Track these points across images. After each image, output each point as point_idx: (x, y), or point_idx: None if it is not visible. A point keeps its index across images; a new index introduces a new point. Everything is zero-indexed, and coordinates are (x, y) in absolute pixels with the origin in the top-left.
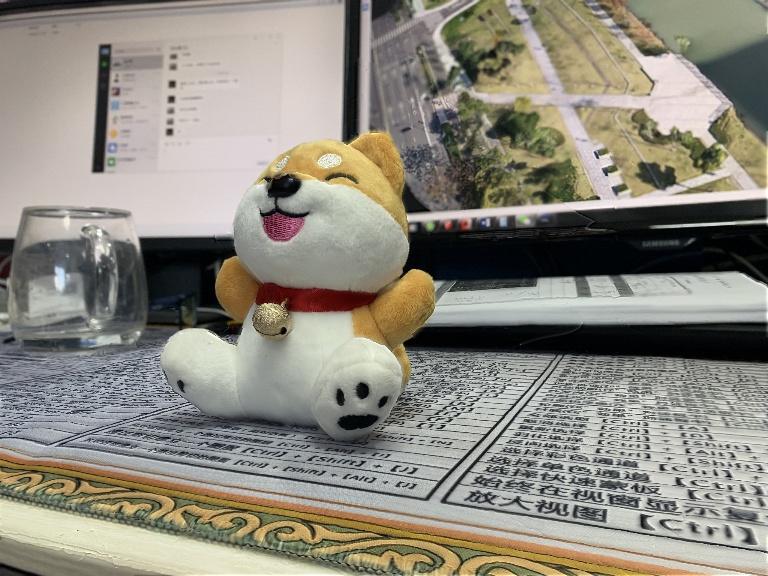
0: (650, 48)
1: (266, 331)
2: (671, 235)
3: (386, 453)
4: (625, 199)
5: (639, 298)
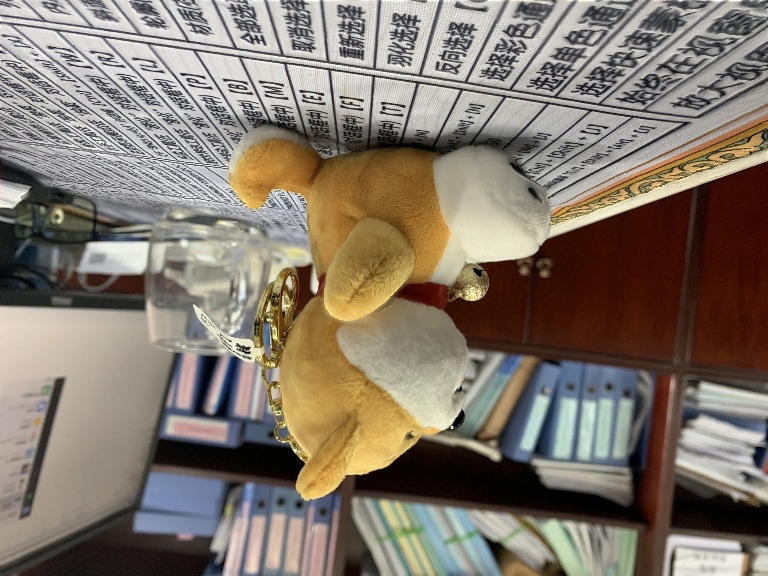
0: None
1: None
2: None
3: None
4: None
5: None
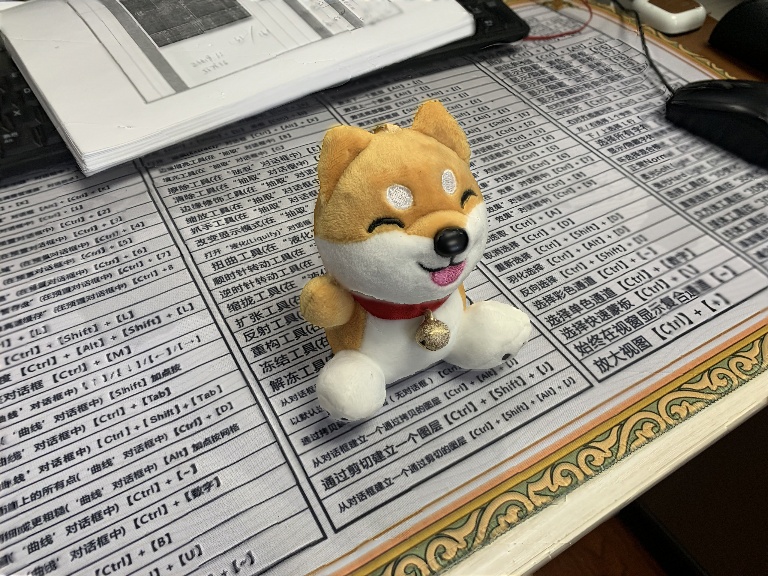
0: None
1: None
2: None
3: None
4: None
5: (371, 29)
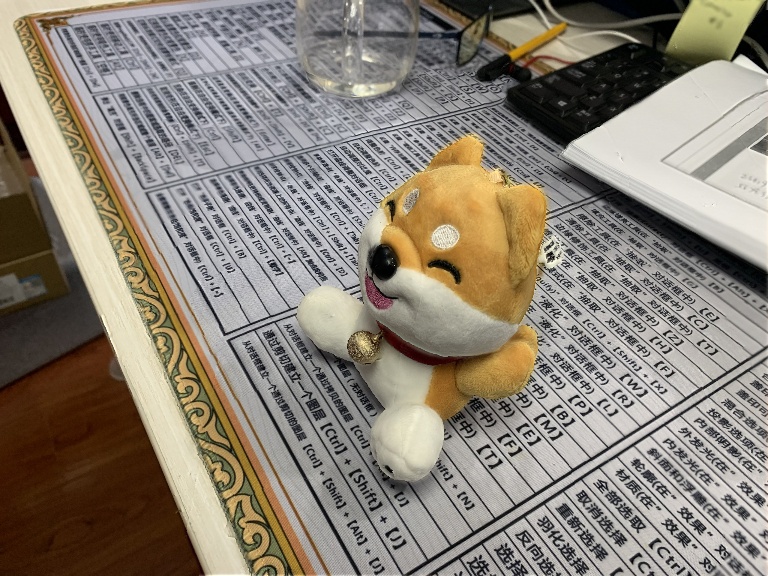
0: None
1: None
2: None
3: (407, 498)
4: None
5: None
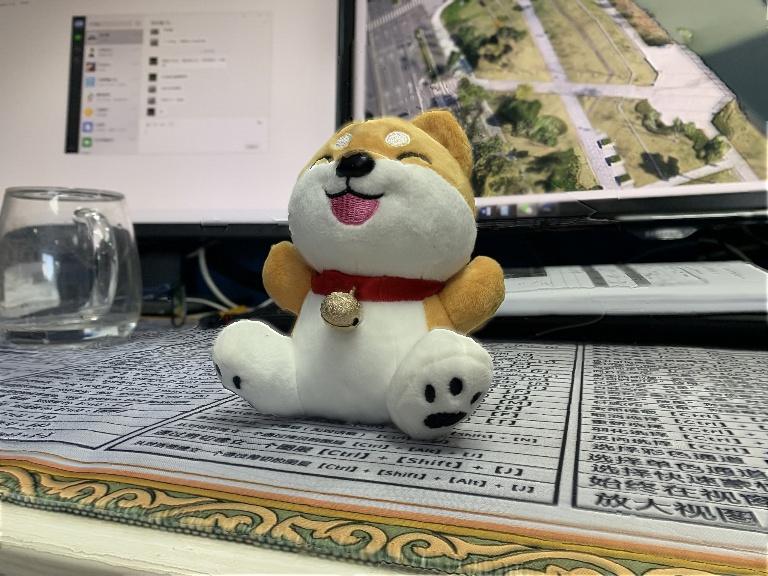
0: (654, 38)
1: (338, 322)
2: (674, 226)
3: (477, 453)
4: (628, 189)
5: (657, 288)
